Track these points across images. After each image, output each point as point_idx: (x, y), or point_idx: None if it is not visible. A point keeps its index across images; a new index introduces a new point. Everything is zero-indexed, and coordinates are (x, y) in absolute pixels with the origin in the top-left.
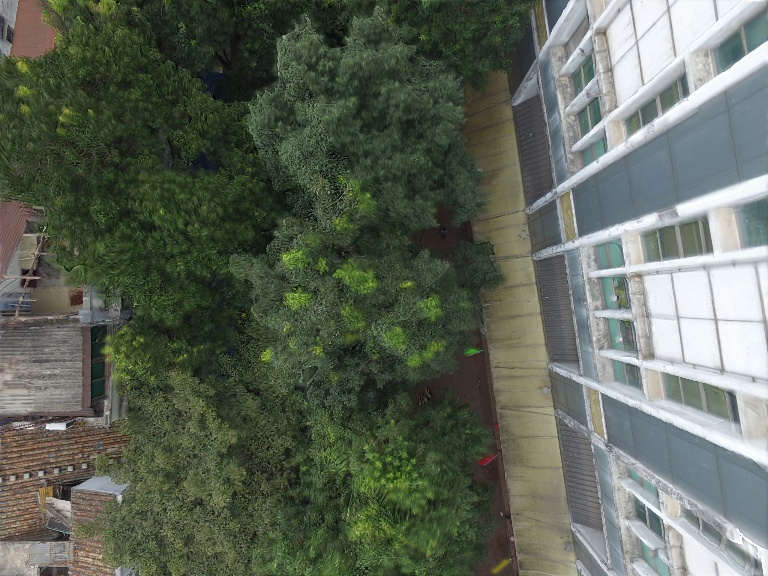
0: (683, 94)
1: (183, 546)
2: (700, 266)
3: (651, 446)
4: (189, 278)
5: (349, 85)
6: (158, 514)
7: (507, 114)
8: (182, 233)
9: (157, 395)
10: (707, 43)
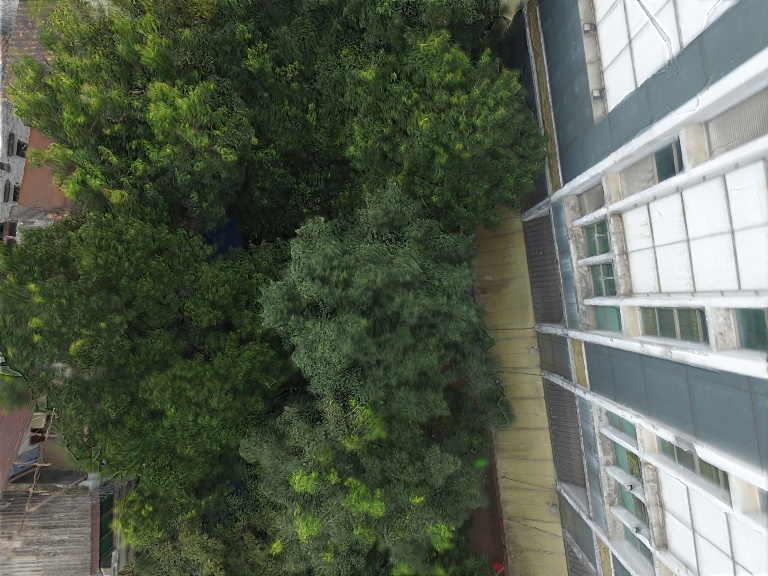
0: (702, 326)
1: None
2: None
3: None
4: (199, 451)
5: (363, 294)
6: None
7: (517, 225)
8: (193, 422)
9: (165, 544)
10: None
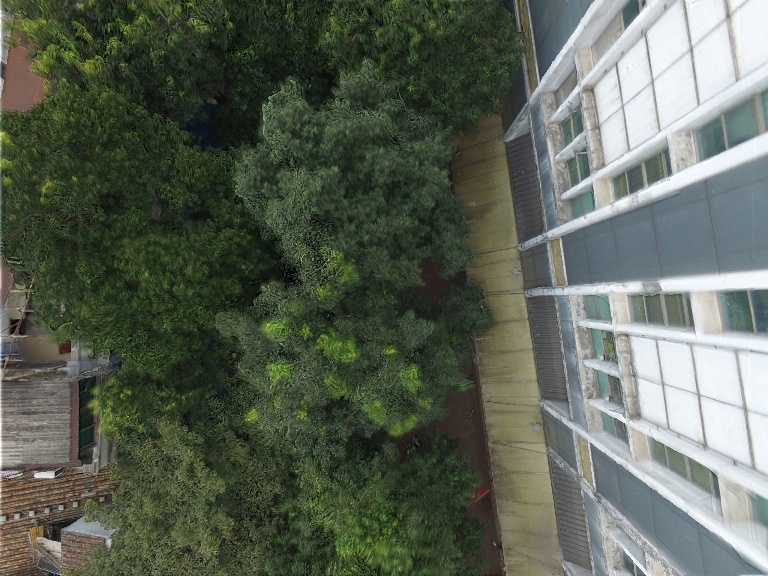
0: (667, 166)
1: None
2: (683, 340)
3: (637, 506)
4: (176, 332)
5: (334, 151)
6: (147, 560)
7: (500, 149)
8: (168, 292)
9: (146, 442)
10: (689, 126)
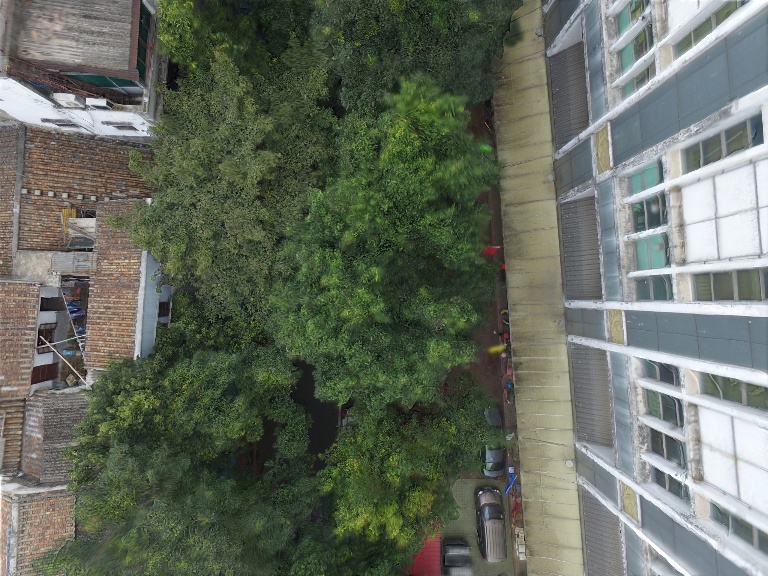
0: None
1: (211, 239)
2: None
3: (660, 118)
4: None
5: None
6: (188, 210)
7: None
8: None
9: (195, 92)
10: None
